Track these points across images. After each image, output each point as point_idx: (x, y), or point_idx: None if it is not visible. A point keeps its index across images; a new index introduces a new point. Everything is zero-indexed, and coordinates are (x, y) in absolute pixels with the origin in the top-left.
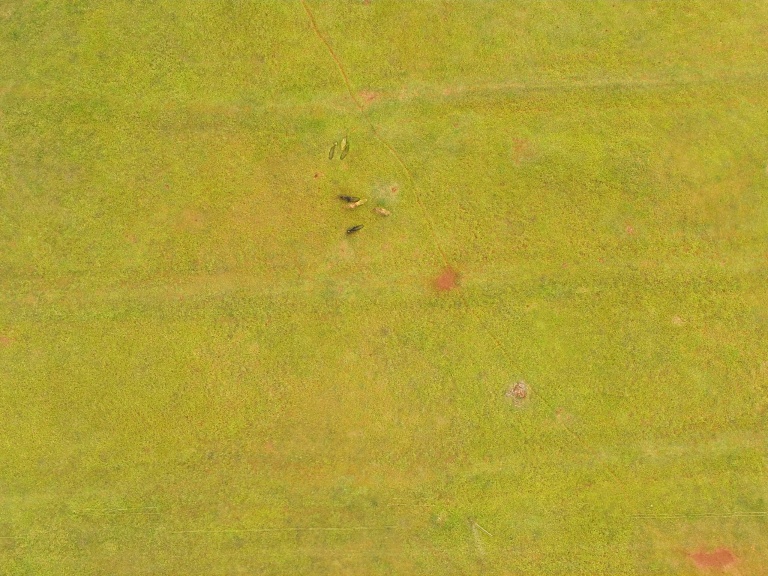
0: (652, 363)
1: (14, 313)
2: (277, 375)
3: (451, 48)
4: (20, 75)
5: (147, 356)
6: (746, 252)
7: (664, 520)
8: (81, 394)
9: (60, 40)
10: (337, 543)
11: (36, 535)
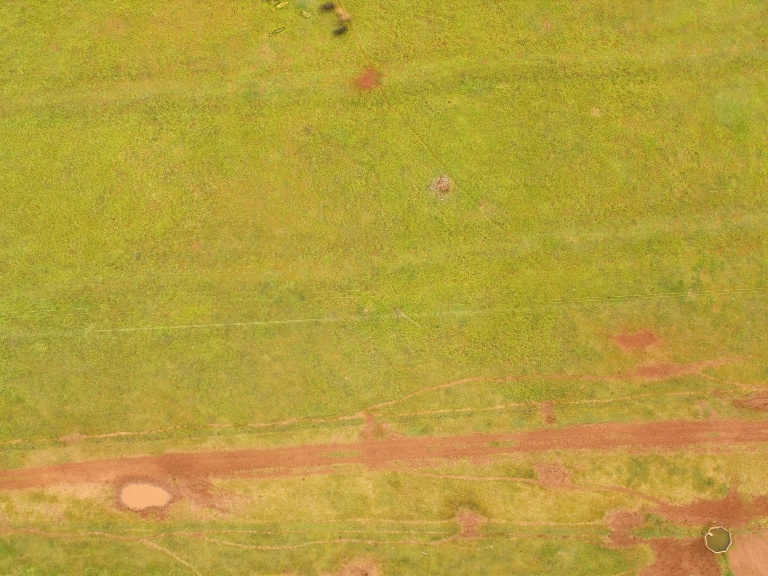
0: (572, 153)
1: None
2: (202, 175)
3: None
4: None
5: (72, 160)
6: (663, 43)
7: (586, 303)
8: (7, 199)
9: None
10: (265, 337)
11: None
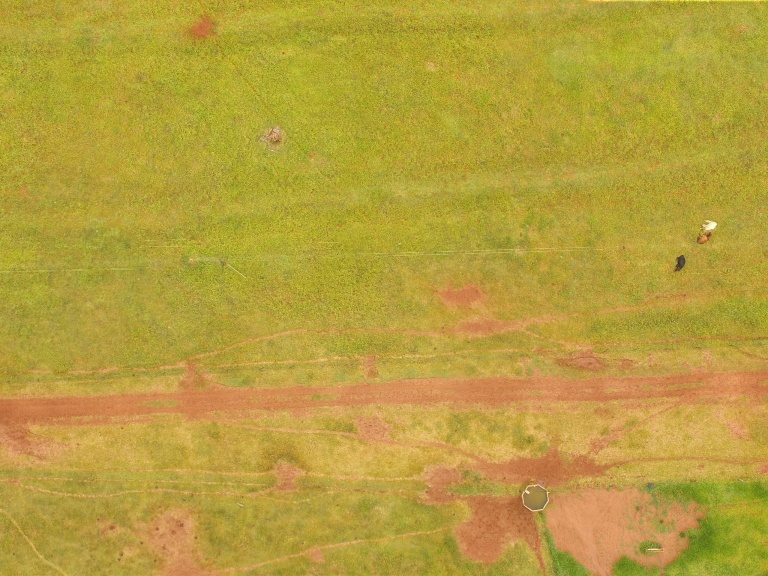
0: (405, 107)
1: None
2: (31, 121)
3: None
4: None
5: None
6: None
7: (412, 258)
8: None
9: None
10: (89, 284)
11: None
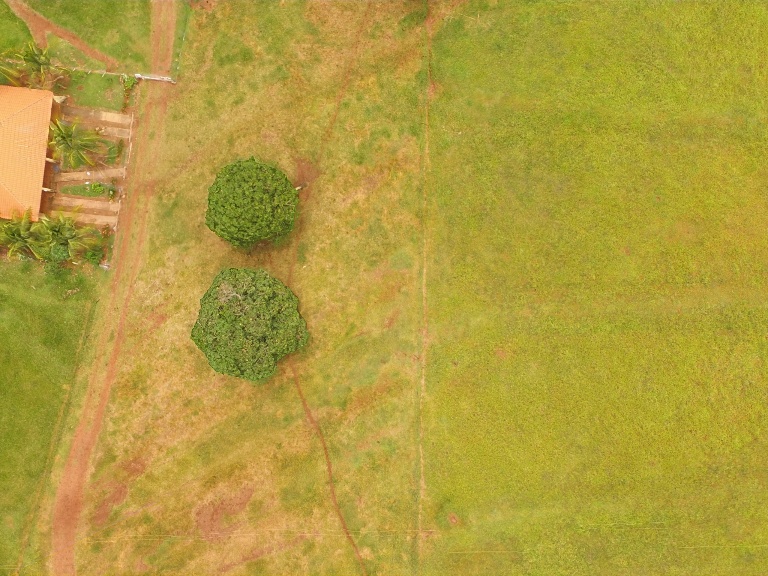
0: None
1: (509, 326)
2: None
3: None
4: (508, 87)
5: (648, 369)
6: None
7: None
8: (583, 408)
9: (546, 51)
10: None
11: (544, 550)
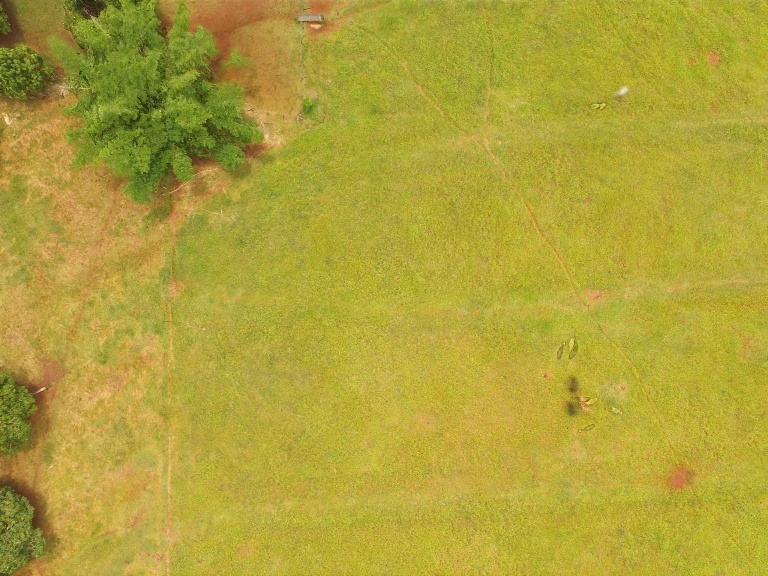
0: None
1: (253, 522)
2: None
3: (673, 245)
4: (249, 283)
5: (388, 562)
6: None
7: None
8: None
9: (287, 246)
10: None
11: None
